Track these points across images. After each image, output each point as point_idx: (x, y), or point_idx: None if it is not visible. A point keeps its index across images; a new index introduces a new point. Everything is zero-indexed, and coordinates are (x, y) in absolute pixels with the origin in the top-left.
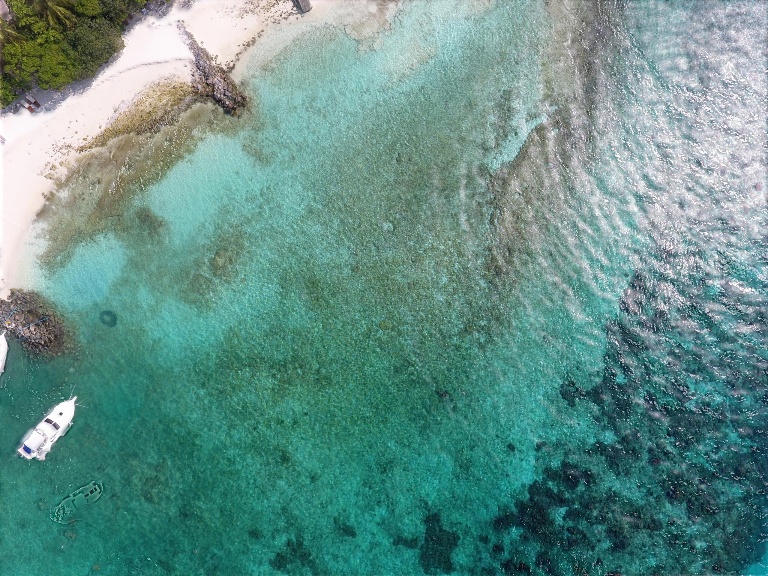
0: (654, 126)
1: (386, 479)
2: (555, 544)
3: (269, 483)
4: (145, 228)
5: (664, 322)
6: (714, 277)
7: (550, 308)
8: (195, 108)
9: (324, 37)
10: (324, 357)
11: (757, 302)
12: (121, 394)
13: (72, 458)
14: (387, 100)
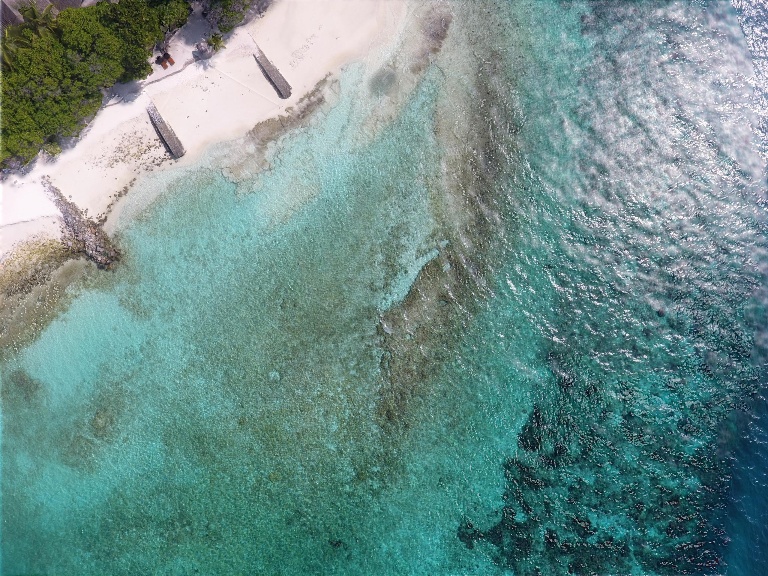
0: (551, 255)
1: None
2: None
3: None
4: (21, 392)
5: (564, 458)
6: (616, 409)
7: (445, 450)
8: (67, 265)
9: (200, 182)
10: (213, 513)
11: (661, 432)
12: (6, 561)
13: None
14: (269, 244)
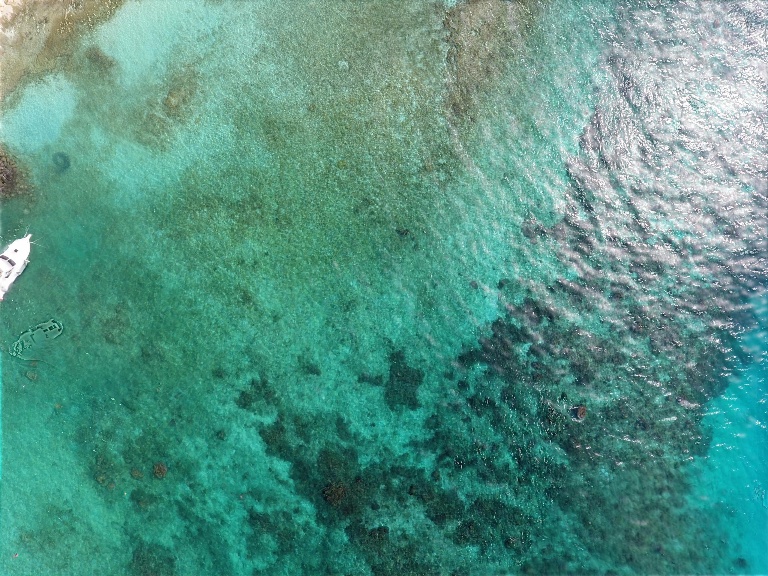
0: None
1: (349, 318)
2: (520, 379)
3: (231, 323)
4: (95, 68)
5: (624, 160)
6: (674, 114)
7: (510, 146)
8: None
9: None
10: (283, 197)
11: (717, 139)
12: (78, 236)
13: (31, 300)
14: None
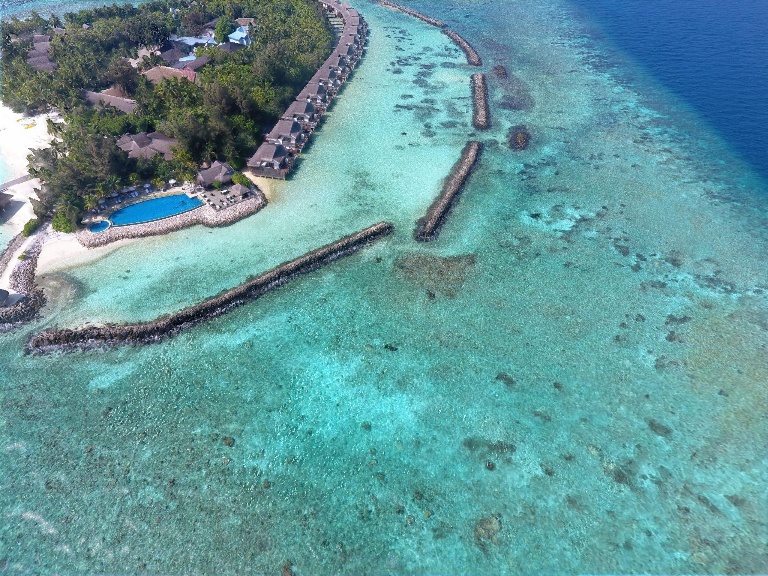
0: None
1: None
2: None
3: None
4: None
5: None
6: None
7: (48, 3)
8: None
9: None
10: None
11: None
12: None
13: None
14: None
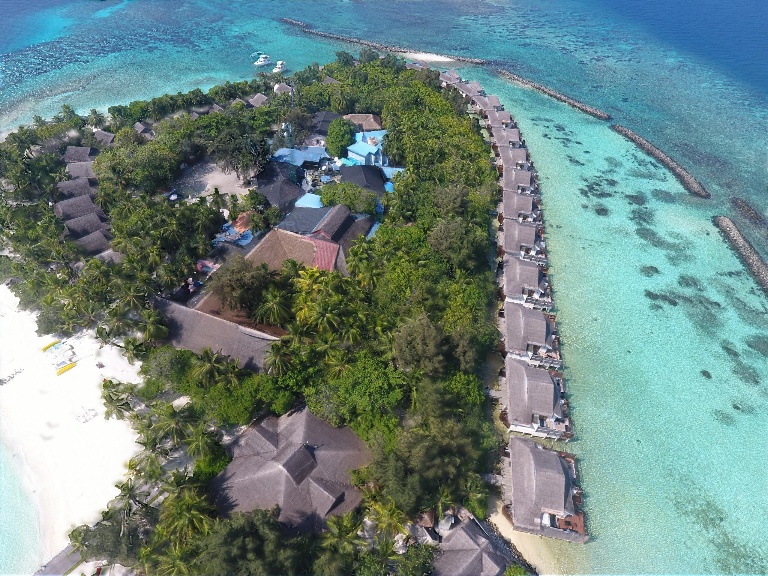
0: None
1: None
2: None
3: None
4: None
5: None
6: (5, 73)
7: None
8: None
9: None
10: None
11: None
12: None
13: None
14: None
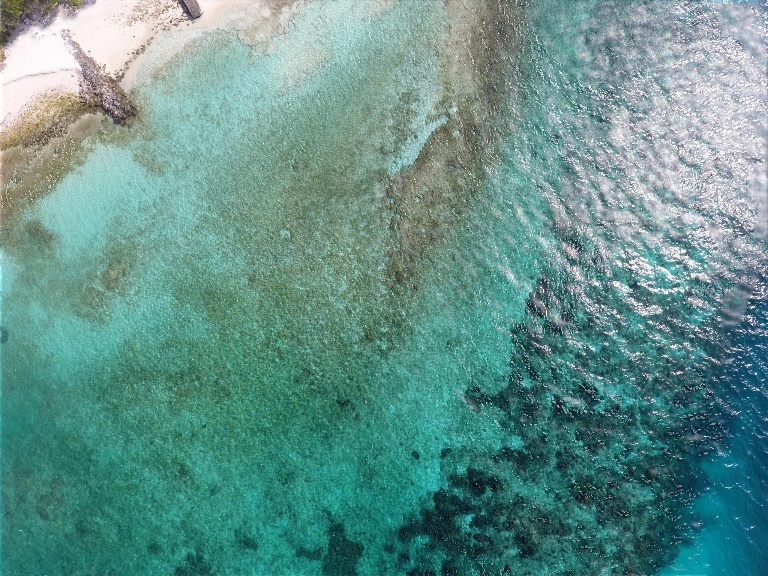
0: (558, 126)
1: (288, 490)
2: (462, 552)
3: (168, 497)
4: (35, 242)
5: (571, 325)
6: (622, 278)
7: (453, 313)
8: (84, 119)
9: (216, 43)
10: (222, 368)
11: (666, 302)
12: (14, 411)
13: None
14: (282, 106)
